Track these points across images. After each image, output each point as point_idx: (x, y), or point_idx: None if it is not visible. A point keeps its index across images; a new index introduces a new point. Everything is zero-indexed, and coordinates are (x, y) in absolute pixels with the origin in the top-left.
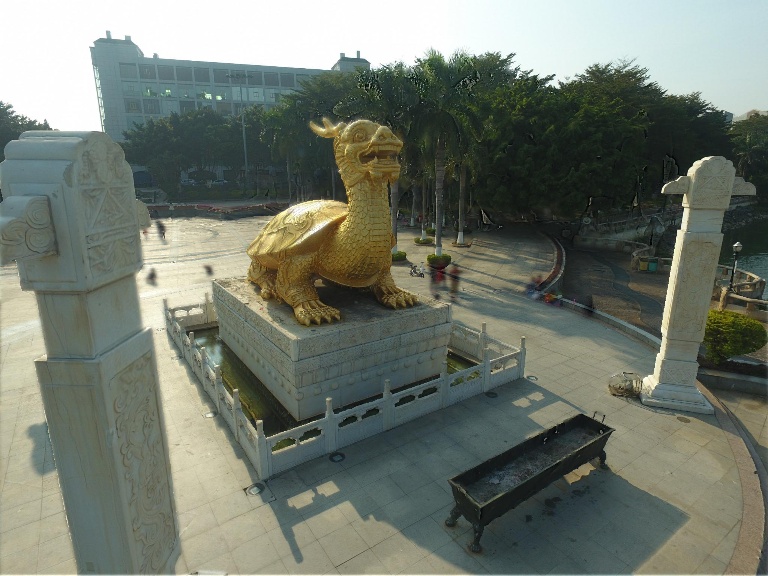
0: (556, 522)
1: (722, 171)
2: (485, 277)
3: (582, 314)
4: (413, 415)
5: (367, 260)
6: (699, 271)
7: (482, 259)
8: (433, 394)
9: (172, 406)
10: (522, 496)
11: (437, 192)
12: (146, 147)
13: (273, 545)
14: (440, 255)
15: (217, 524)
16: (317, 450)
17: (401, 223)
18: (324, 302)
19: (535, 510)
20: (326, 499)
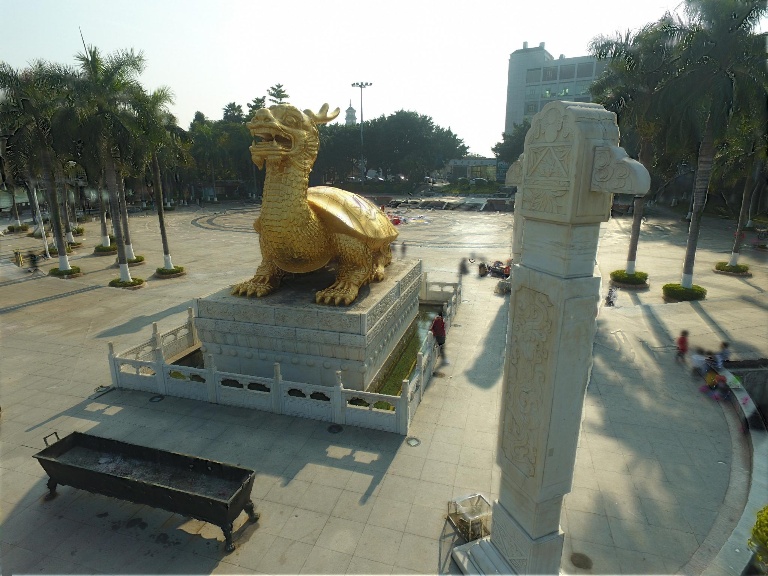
0: (101, 534)
1: (560, 134)
2: (698, 328)
3: (734, 425)
4: (241, 402)
5: (269, 244)
6: (531, 350)
7: (767, 306)
8: (266, 392)
9: None
10: (95, 486)
11: (695, 193)
12: (515, 146)
13: (43, 417)
14: (686, 286)
15: (61, 393)
16: (152, 386)
17: (765, 242)
18: (301, 284)
19: (118, 515)
20: (99, 414)
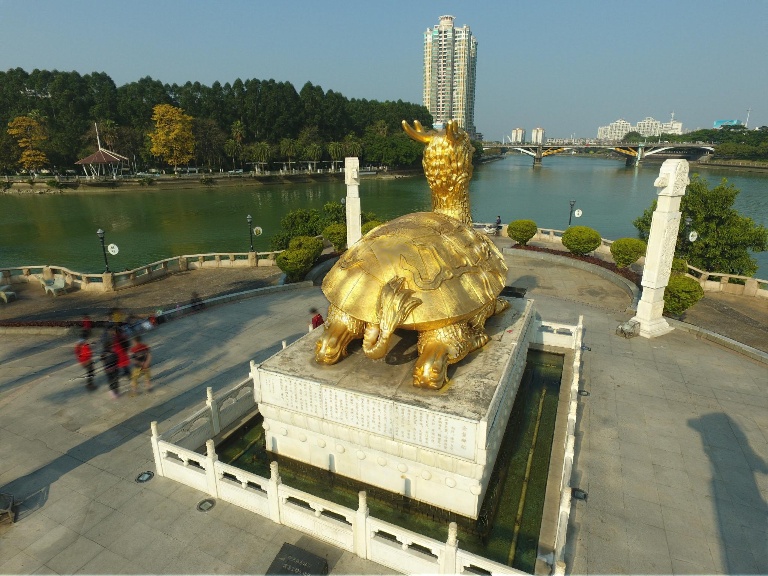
0: None
1: None
2: None
3: (200, 311)
4: None
5: None
6: None
7: None
8: None
9: (613, 416)
10: None
11: None
12: None
13: None
14: None
15: (611, 347)
16: None
17: None
18: None
19: None
20: None
